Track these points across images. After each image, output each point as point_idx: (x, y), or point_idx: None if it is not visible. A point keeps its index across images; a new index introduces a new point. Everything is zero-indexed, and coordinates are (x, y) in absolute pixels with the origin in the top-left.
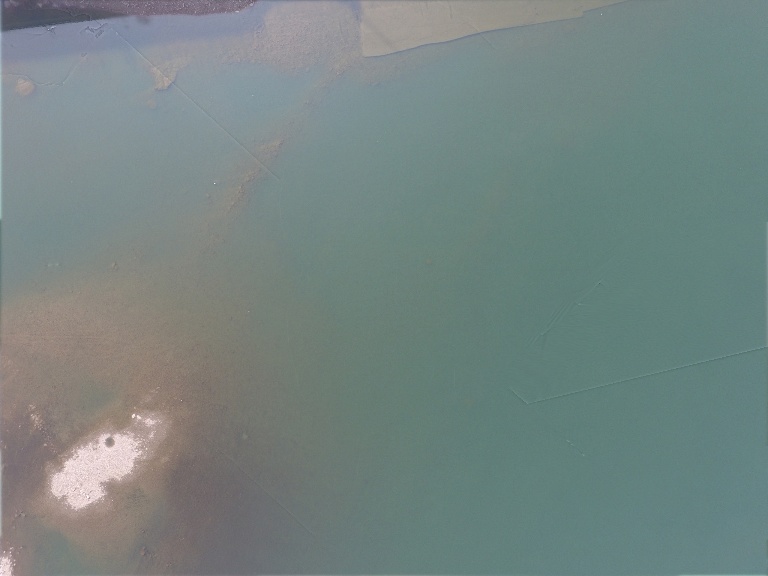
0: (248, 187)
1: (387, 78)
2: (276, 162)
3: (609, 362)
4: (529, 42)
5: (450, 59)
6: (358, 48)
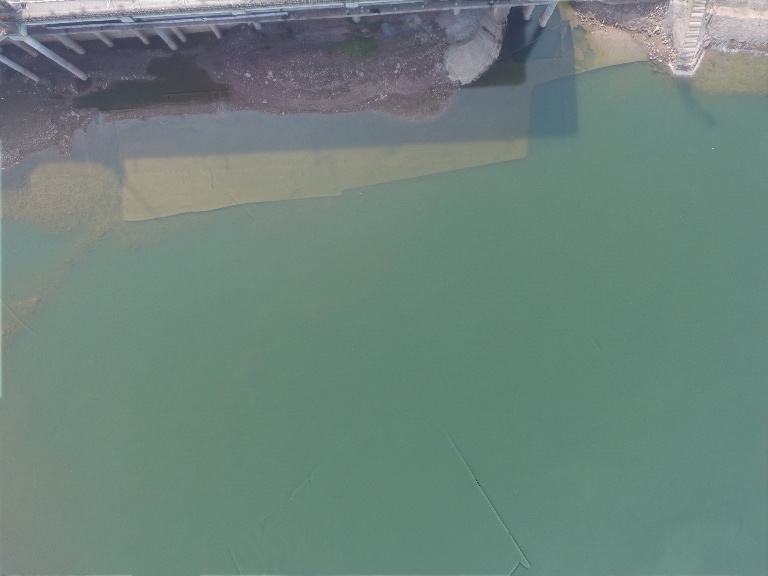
0: (3, 341)
1: (147, 242)
2: (33, 318)
3: (297, 570)
4: (289, 216)
5: (210, 227)
6: (119, 212)
